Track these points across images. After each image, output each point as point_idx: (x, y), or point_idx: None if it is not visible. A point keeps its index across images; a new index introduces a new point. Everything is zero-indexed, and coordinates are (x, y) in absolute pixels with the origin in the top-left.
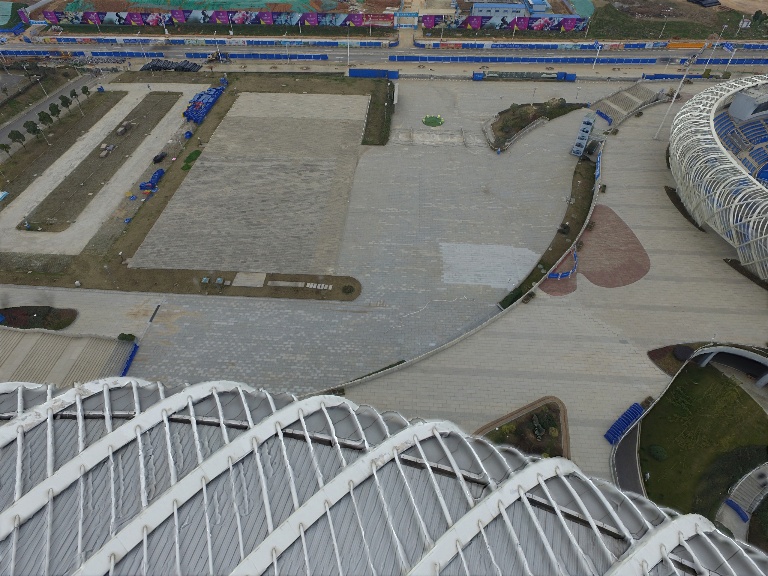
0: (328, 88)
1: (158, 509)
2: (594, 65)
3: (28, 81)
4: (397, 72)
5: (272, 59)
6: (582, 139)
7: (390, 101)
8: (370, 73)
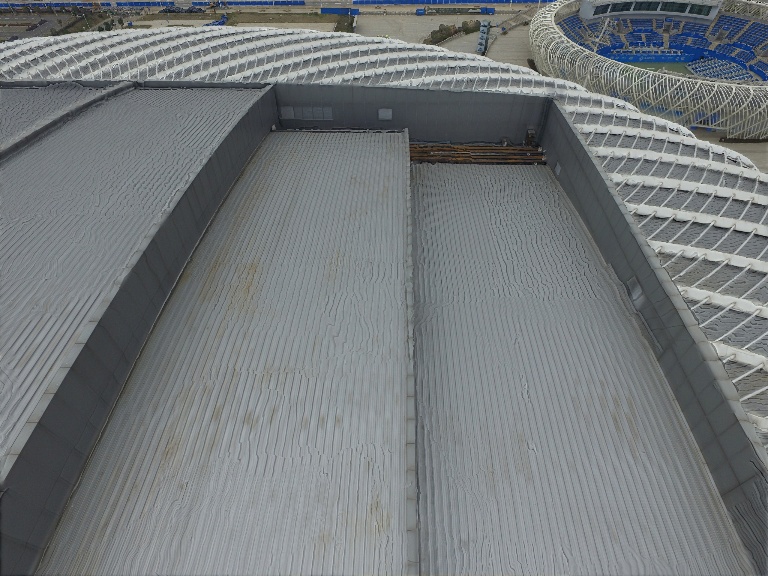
0: (304, 20)
1: (231, 30)
2: (512, 4)
3: (73, 19)
4: (358, 10)
5: (261, 5)
6: (482, 39)
7: (351, 27)
8: (337, 11)
